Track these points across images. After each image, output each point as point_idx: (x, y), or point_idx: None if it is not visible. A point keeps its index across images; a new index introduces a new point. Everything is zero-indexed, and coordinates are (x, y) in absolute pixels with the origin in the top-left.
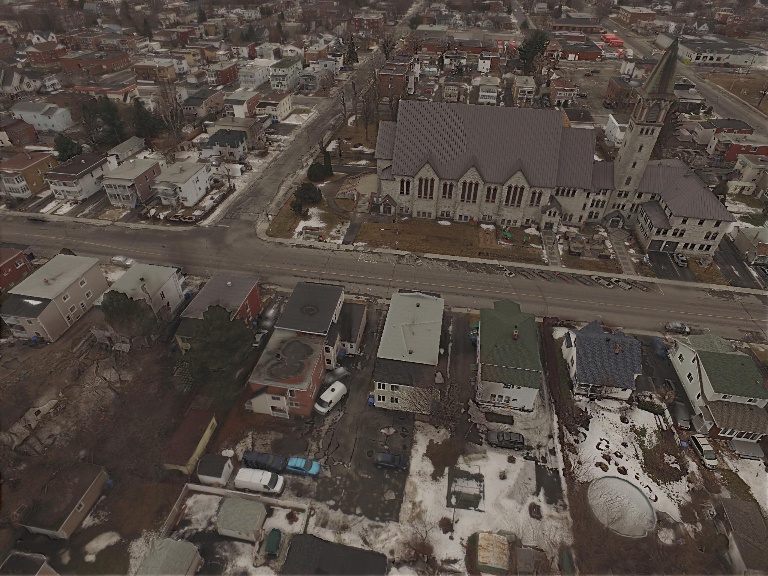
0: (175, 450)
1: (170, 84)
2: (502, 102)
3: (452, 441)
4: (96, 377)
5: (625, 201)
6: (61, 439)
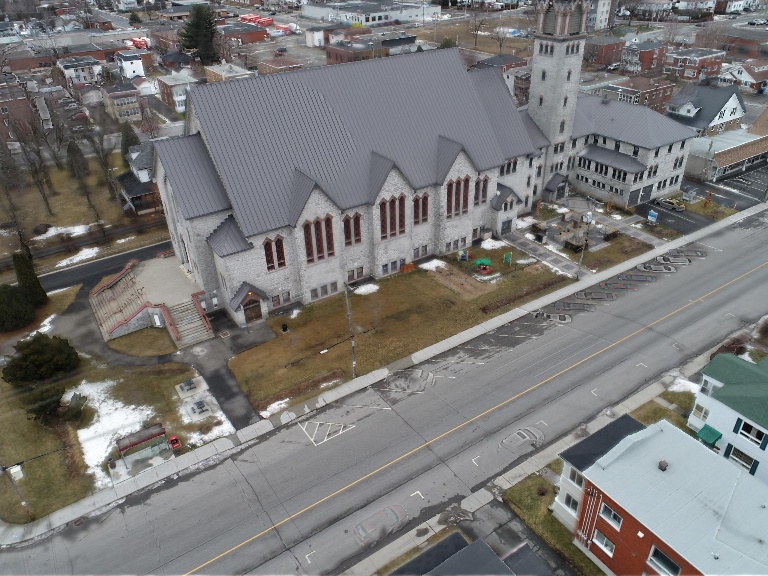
0: None
1: None
2: None
3: None
4: None
5: (562, 157)
6: None
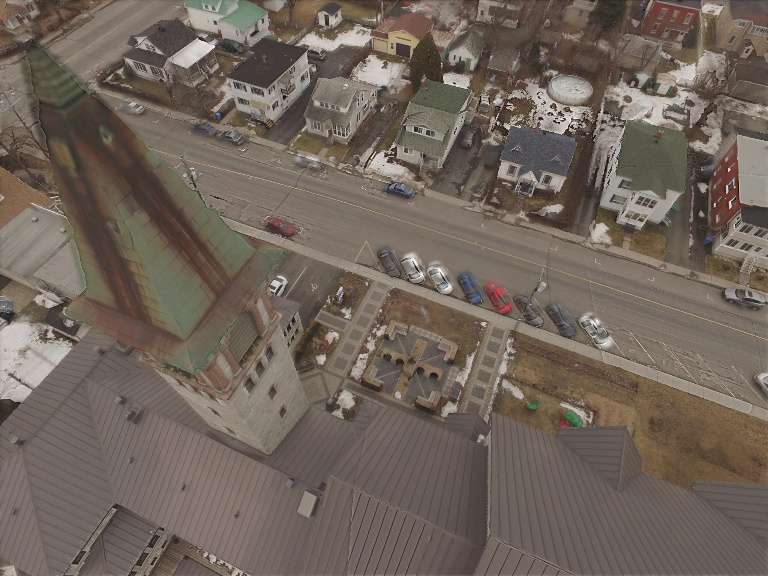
0: None
1: None
2: None
3: None
4: None
5: None
6: None
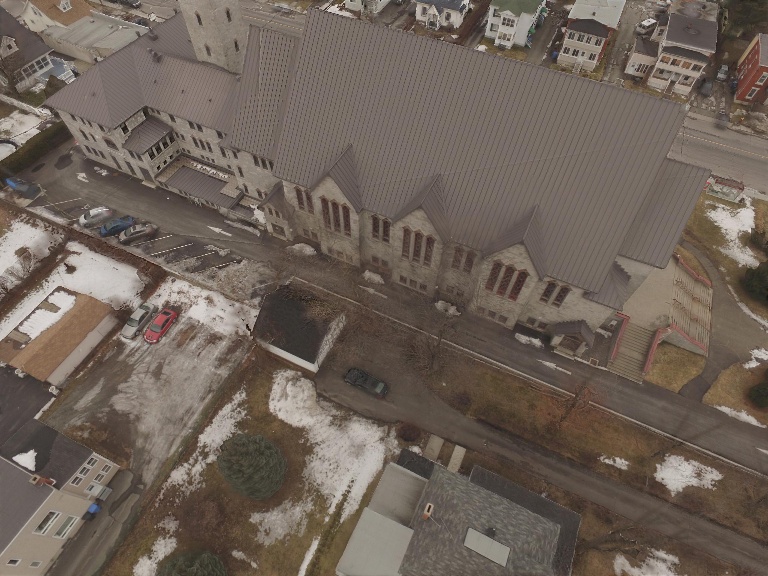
0: None
1: None
2: None
3: None
4: None
5: None
6: None
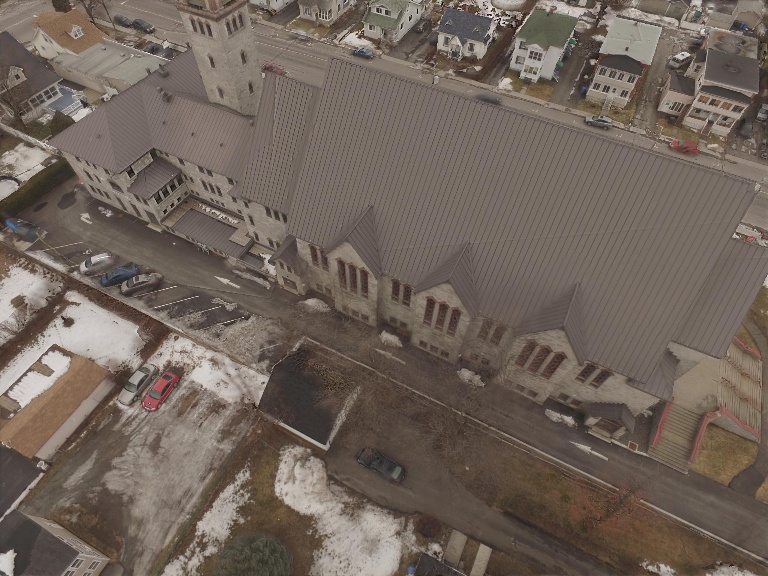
0: None
1: None
2: None
3: None
4: None
5: None
6: None
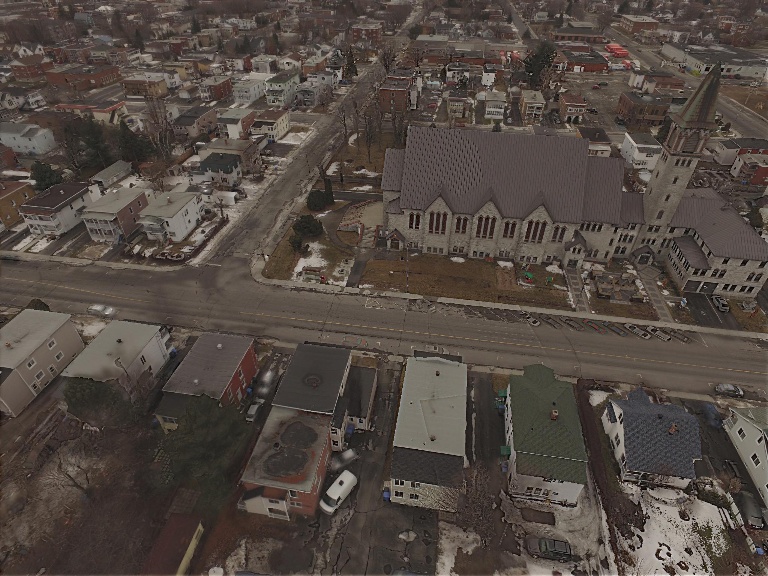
0: (151, 575)
1: (159, 103)
2: (510, 118)
3: (485, 553)
4: (63, 464)
5: (656, 236)
6: (15, 553)
